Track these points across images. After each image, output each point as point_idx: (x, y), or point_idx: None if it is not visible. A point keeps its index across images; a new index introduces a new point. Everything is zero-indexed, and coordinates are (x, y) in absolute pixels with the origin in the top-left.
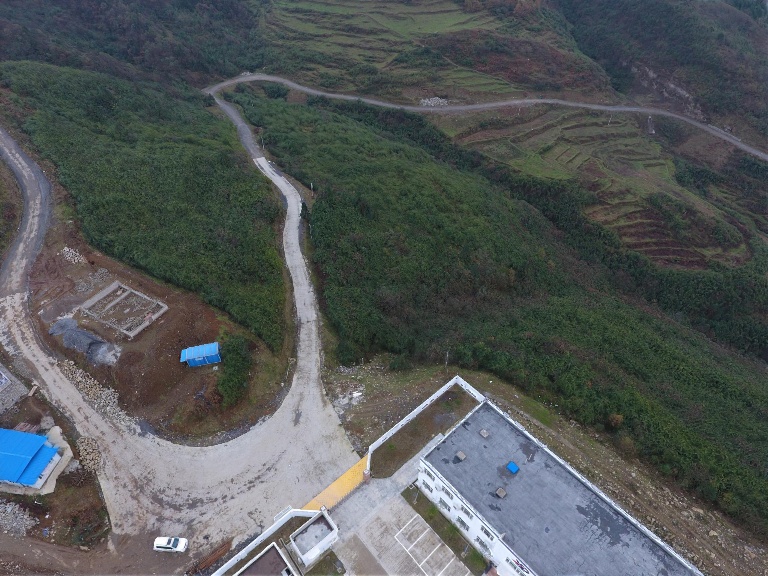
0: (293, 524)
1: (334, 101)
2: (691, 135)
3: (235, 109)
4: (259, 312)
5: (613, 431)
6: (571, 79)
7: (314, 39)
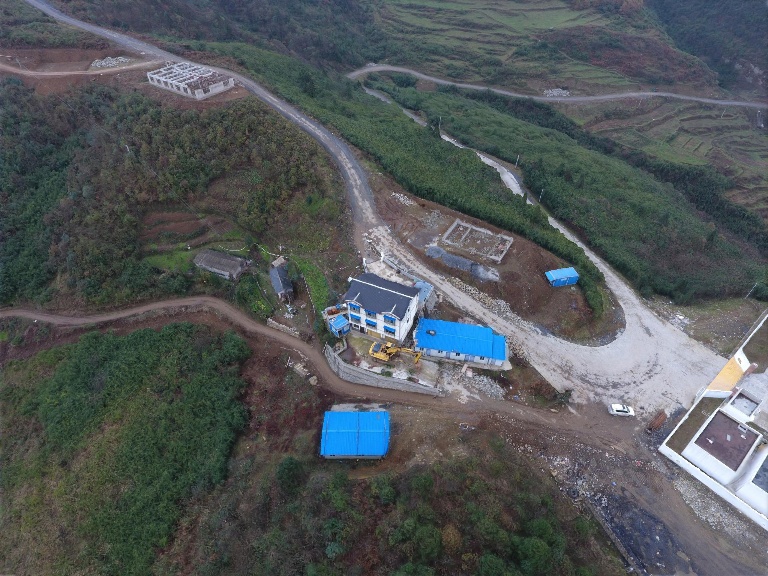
0: (705, 402)
1: (465, 90)
2: None
3: (382, 95)
4: None
5: None
6: (683, 74)
7: (432, 33)
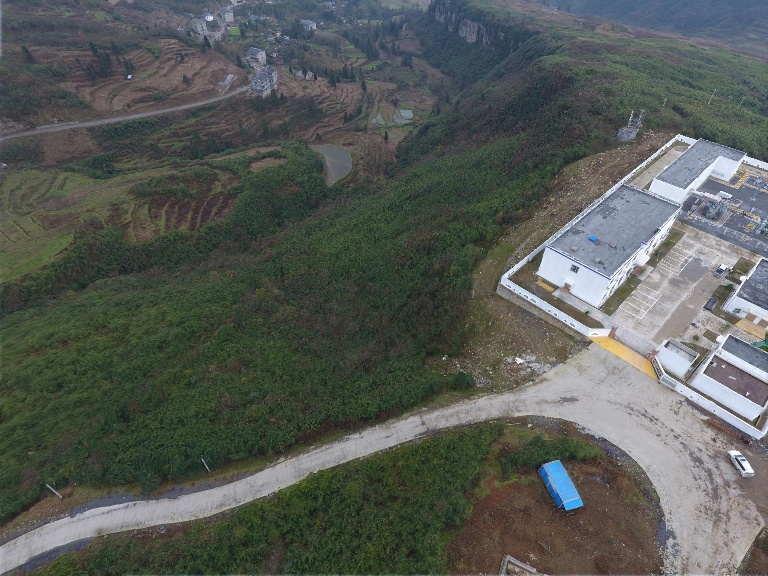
0: None
1: None
2: (39, 144)
3: None
4: None
5: (502, 224)
6: None
7: None
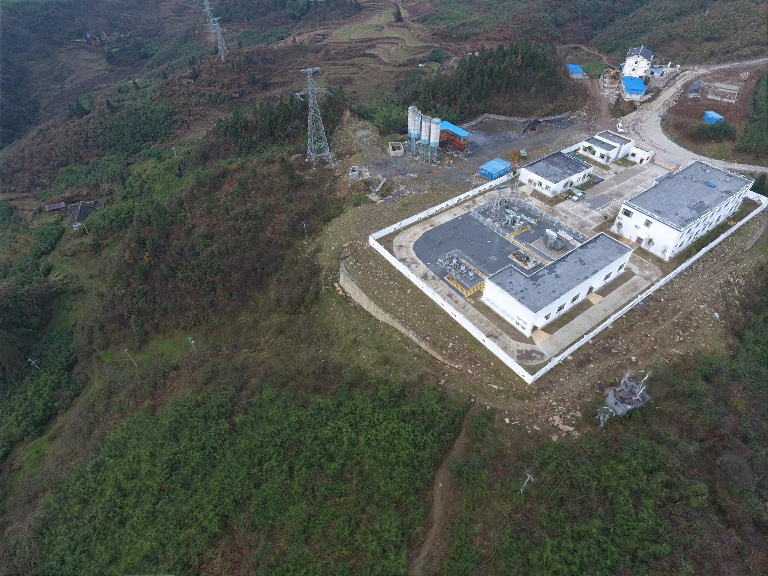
0: None
1: None
2: None
3: None
4: (760, 138)
5: None
6: None
7: None
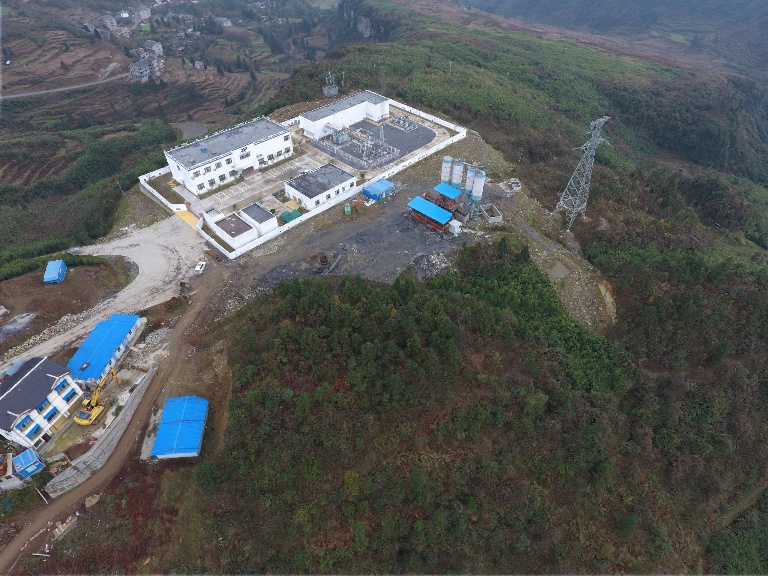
0: None
1: None
2: None
3: None
4: None
5: None
6: None
7: None
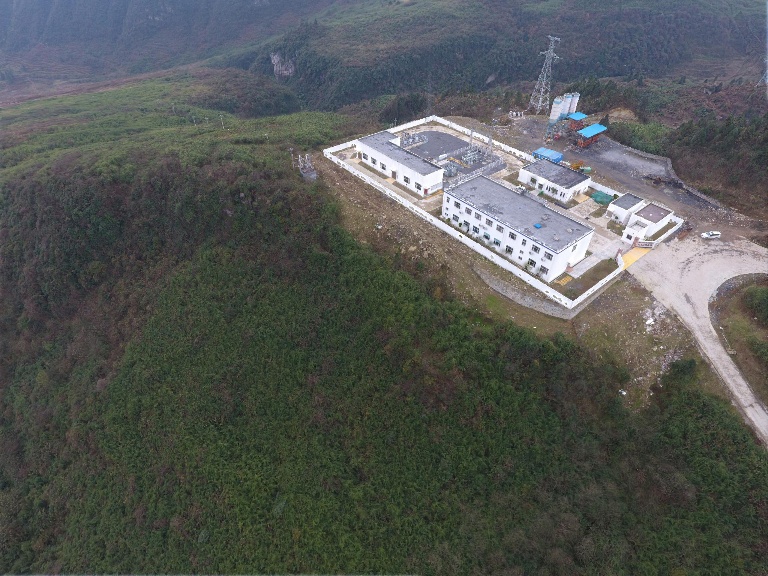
0: None
1: None
2: None
3: None
4: None
5: None
6: None
7: None
